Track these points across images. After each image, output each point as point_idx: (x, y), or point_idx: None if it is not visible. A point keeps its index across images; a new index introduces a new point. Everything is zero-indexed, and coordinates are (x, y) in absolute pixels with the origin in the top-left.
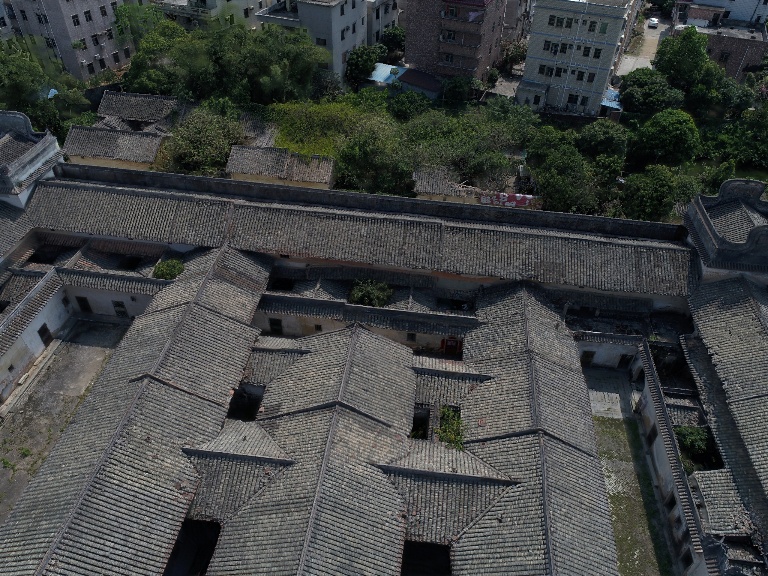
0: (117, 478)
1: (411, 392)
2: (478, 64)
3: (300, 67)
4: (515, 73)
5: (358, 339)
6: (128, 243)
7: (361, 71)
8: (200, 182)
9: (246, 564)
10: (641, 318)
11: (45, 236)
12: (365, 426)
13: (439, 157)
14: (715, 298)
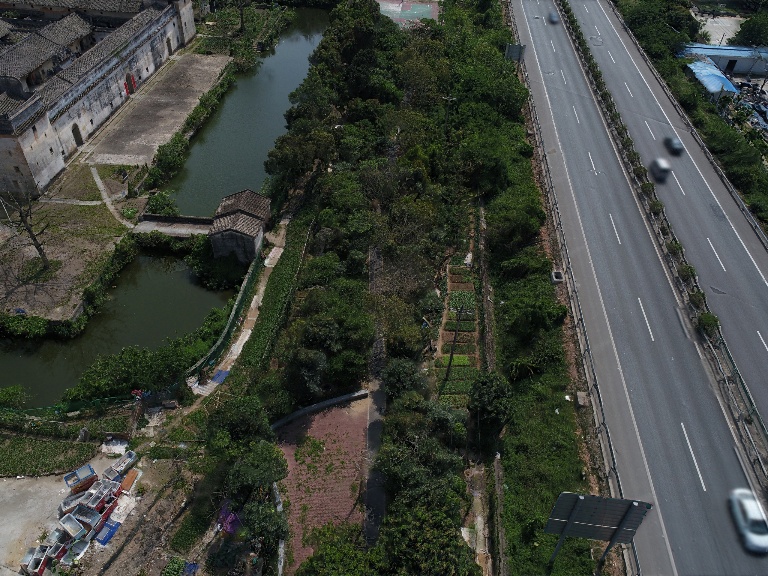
0: None
1: (3, 33)
2: None
3: None
4: None
5: None
6: None
7: None
8: None
9: None
10: None
11: None
12: None
13: None
14: None
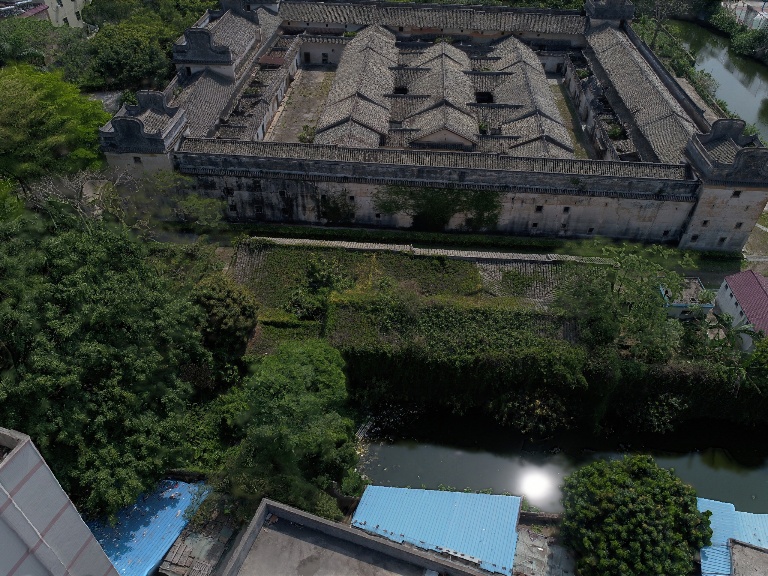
0: None
1: (469, 62)
2: None
3: None
4: None
5: (445, 45)
6: (326, 29)
7: None
8: (355, 3)
9: (422, 87)
10: (566, 50)
11: (285, 28)
12: None
13: (464, 1)
14: (595, 31)
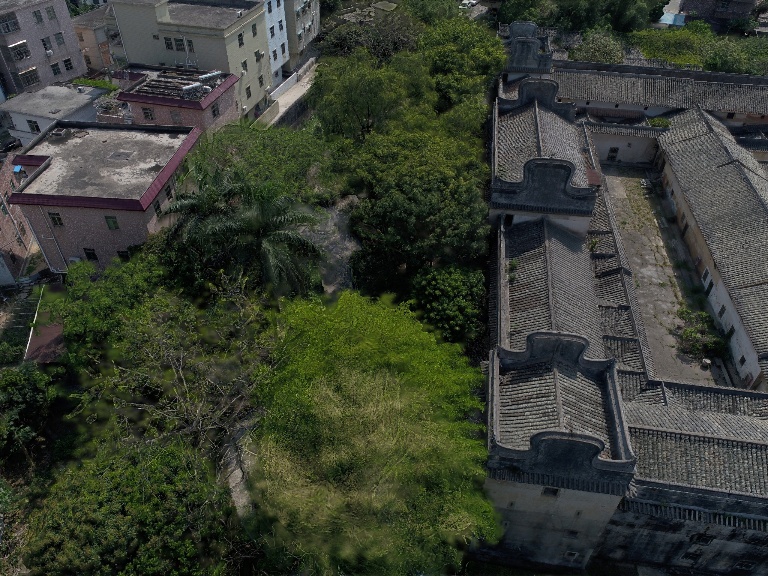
0: (767, 202)
1: None
2: (753, 8)
3: (646, 5)
4: (760, 21)
5: None
6: (614, 110)
7: (655, 16)
8: (651, 71)
9: None
10: None
11: None
12: None
13: None
14: None
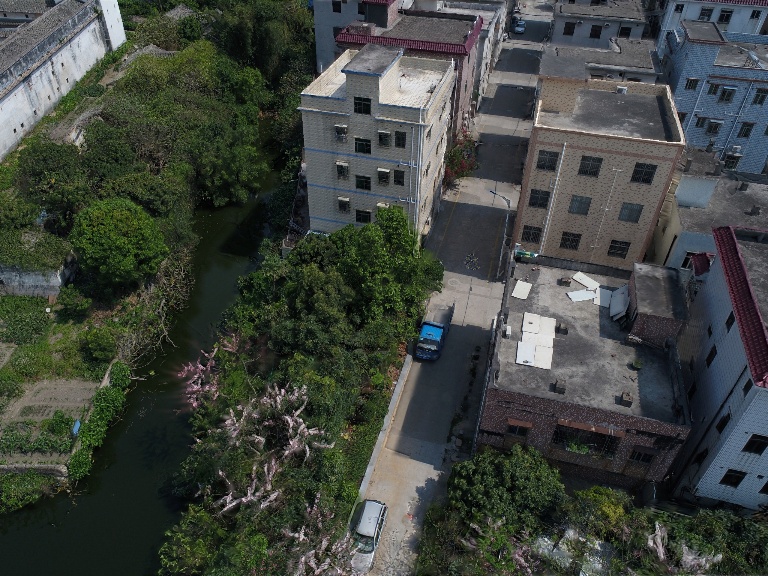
0: None
1: None
2: None
3: None
4: None
5: None
6: None
7: None
8: None
9: None
10: None
11: None
12: None
13: None
14: None
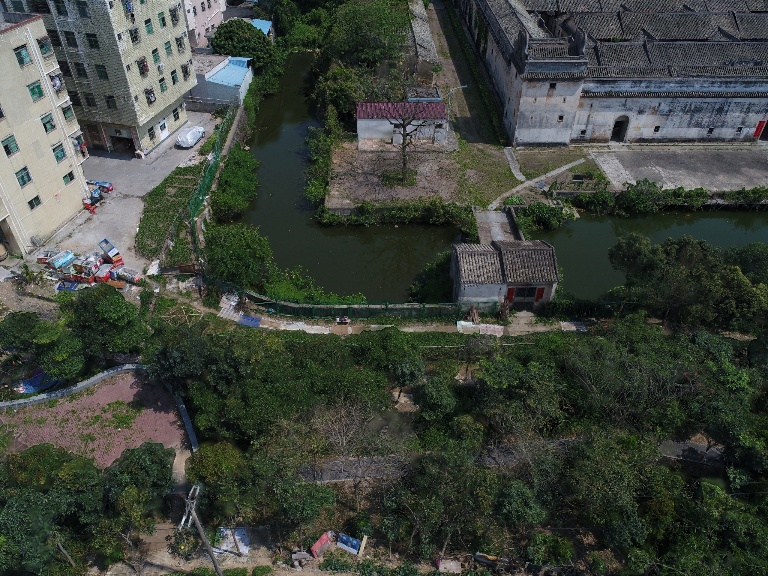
0: None
1: (762, 36)
2: None
3: None
4: None
5: None
6: None
7: None
8: None
9: None
10: None
11: None
12: (732, 23)
13: None
14: None
